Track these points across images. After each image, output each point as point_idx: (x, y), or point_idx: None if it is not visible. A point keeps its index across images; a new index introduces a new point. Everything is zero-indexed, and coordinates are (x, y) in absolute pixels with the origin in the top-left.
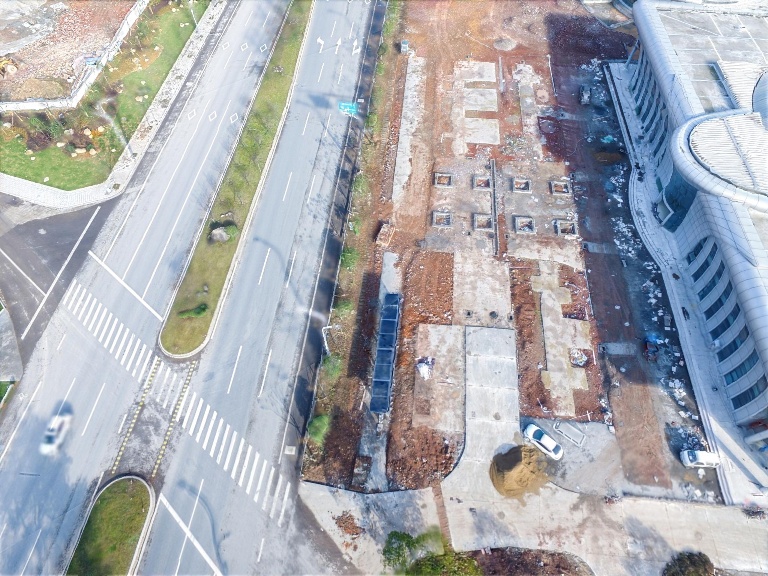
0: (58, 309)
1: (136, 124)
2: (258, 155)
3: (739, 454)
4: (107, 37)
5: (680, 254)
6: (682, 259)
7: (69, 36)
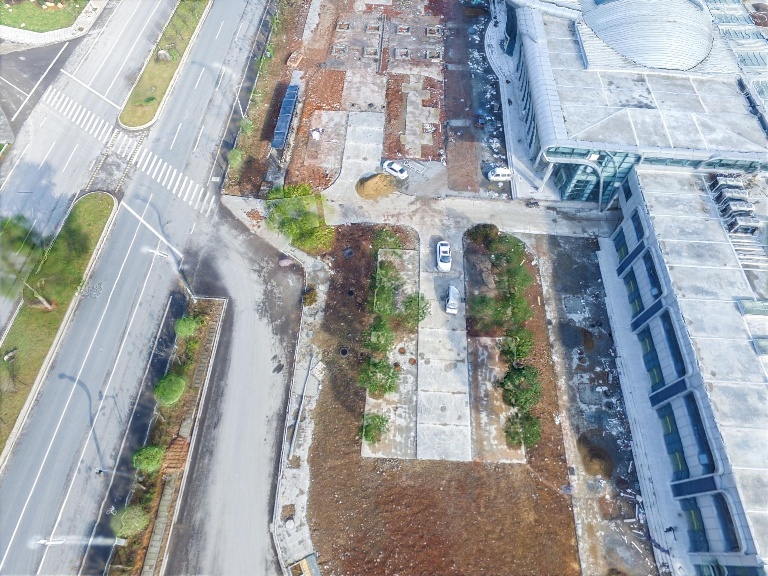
0: (39, 103)
1: None
2: (196, 9)
3: (528, 174)
4: None
5: (514, 69)
6: (515, 72)
7: None
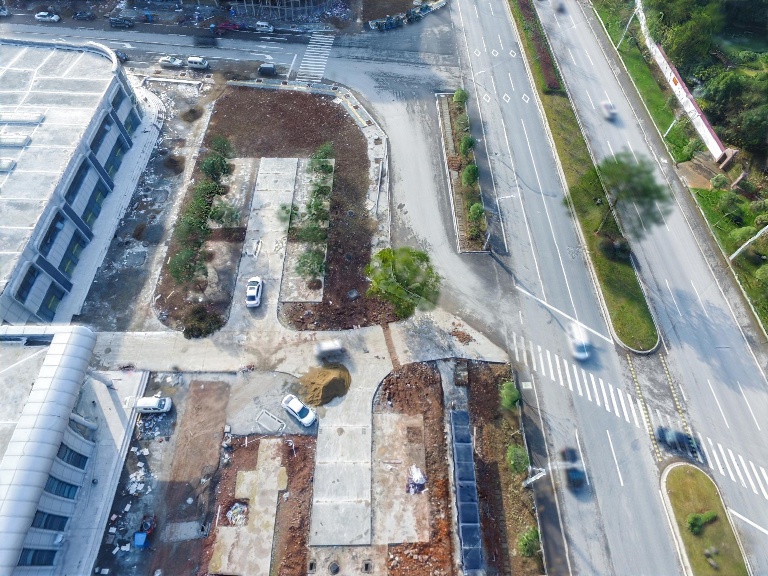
0: None
1: None
2: None
3: (111, 414)
4: None
5: None
6: None
7: None
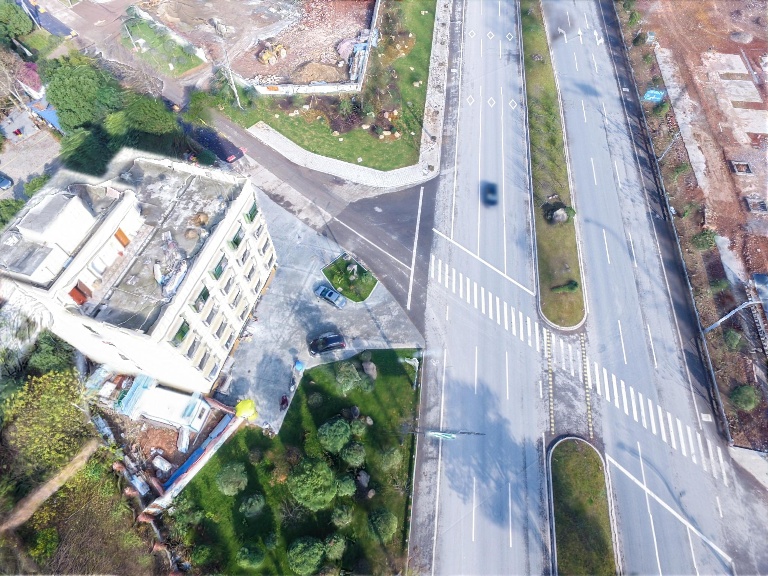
0: (430, 282)
1: (422, 108)
2: (556, 140)
3: None
4: (356, 23)
5: None
6: None
7: (322, 22)
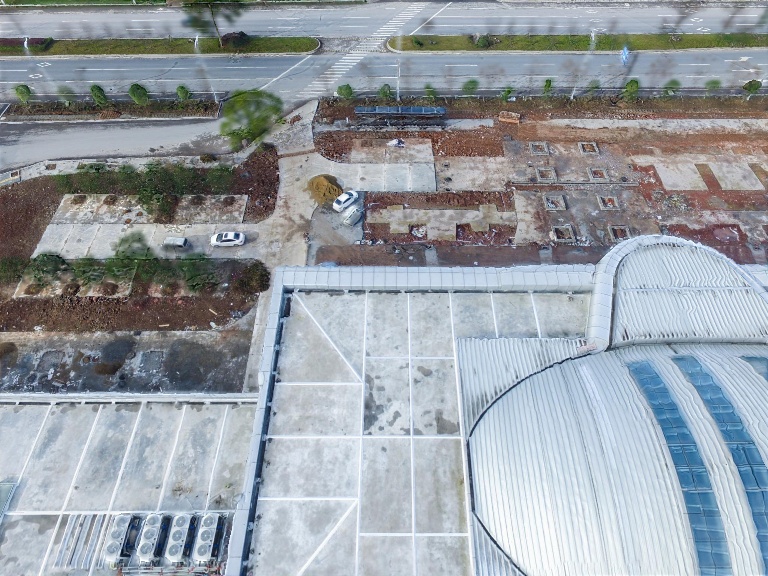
0: (410, 2)
1: None
2: (563, 44)
3: None
4: None
5: None
6: None
7: None
